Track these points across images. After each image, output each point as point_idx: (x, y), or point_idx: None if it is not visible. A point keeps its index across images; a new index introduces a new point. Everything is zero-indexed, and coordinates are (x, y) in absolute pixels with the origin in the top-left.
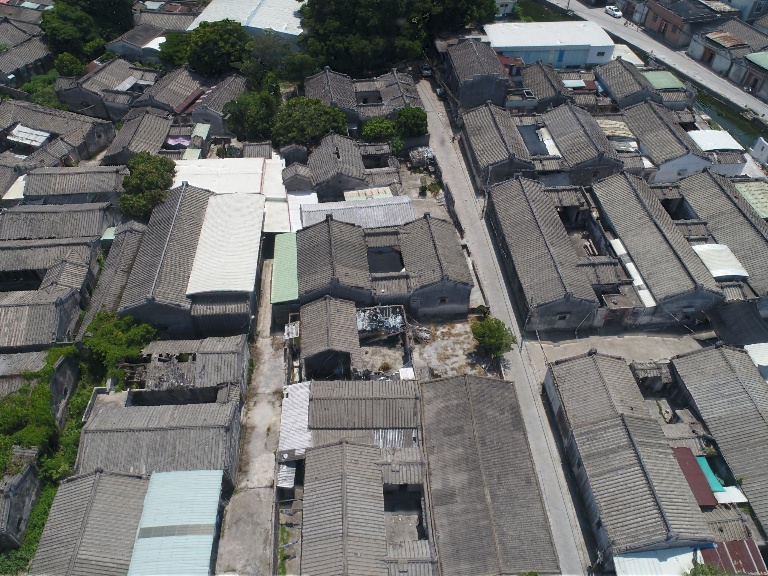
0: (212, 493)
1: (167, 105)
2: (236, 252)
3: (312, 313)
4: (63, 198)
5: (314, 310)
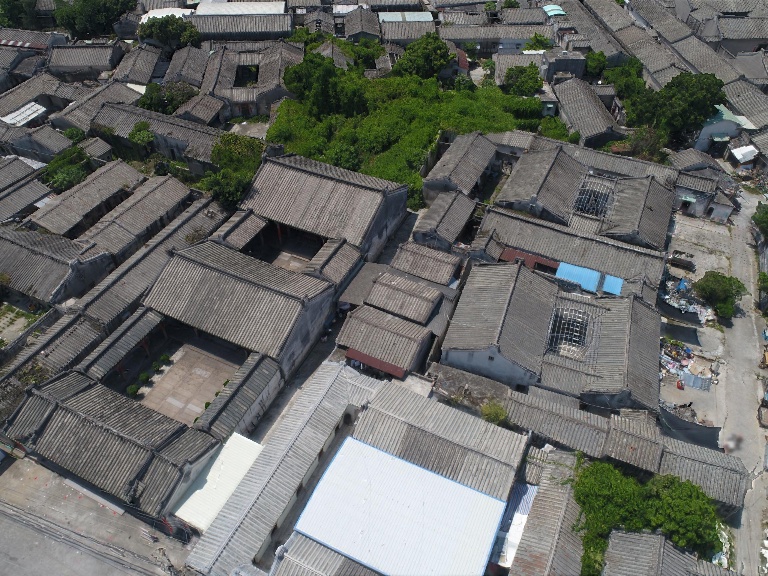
0: None
1: (31, 51)
2: (255, 4)
3: (294, 2)
4: (156, 73)
5: (293, 2)
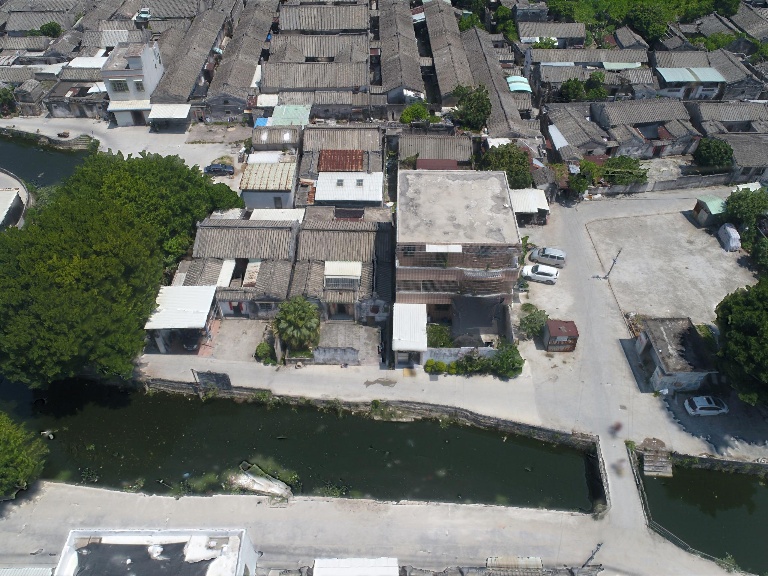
0: (714, 79)
1: None
2: None
3: None
4: None
5: None
